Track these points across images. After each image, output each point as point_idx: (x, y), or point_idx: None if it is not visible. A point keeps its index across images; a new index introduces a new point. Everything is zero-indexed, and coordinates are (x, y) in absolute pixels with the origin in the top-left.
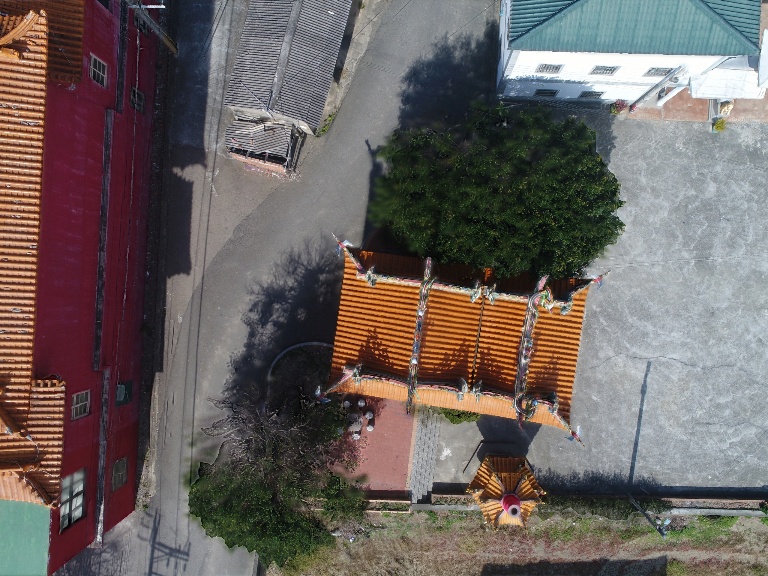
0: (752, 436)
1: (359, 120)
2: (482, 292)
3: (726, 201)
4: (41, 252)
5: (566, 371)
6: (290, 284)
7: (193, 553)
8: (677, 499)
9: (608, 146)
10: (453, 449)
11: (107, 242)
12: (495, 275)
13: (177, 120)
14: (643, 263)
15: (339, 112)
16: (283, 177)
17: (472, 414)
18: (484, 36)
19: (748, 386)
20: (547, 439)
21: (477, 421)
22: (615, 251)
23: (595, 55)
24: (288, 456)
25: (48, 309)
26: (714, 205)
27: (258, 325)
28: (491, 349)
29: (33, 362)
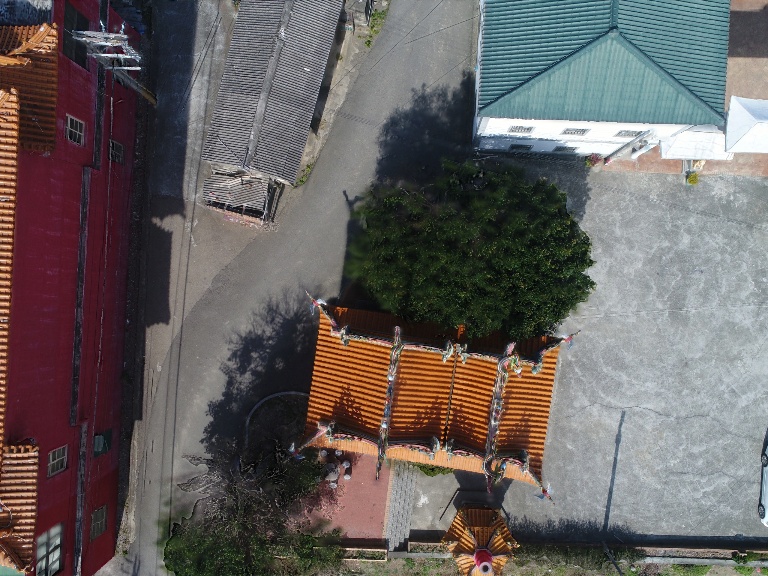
0: (725, 485)
1: (337, 171)
2: (454, 350)
3: (700, 253)
4: (14, 321)
5: (538, 428)
6: (268, 334)
7: None
8: (651, 548)
9: (583, 197)
10: (430, 497)
11: (84, 298)
12: (466, 335)
13: (156, 170)
14: (618, 313)
15: (317, 163)
16: (261, 227)
17: (446, 467)
18: (460, 88)
19: (721, 436)
20: (523, 487)
21: None
22: (590, 301)
23: (564, 120)
24: (261, 514)
25: (22, 373)
26: (688, 257)
27: (236, 374)
28: (463, 406)
29: (6, 429)
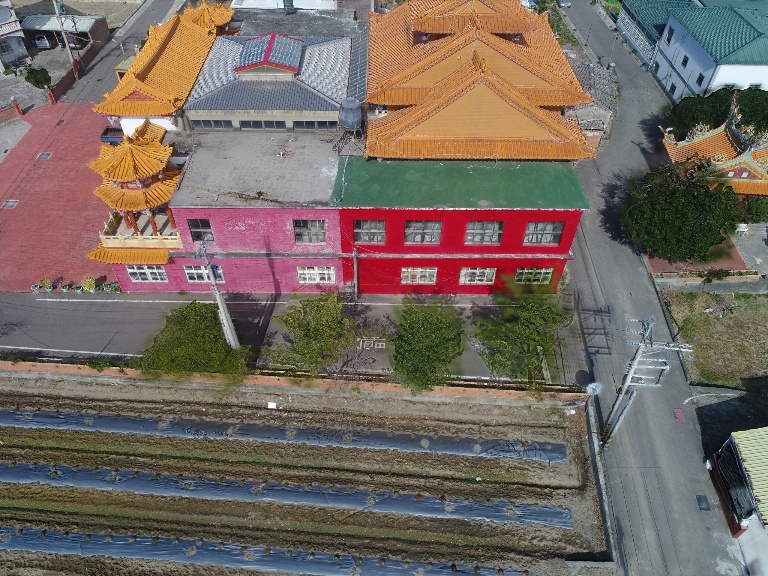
0: None
1: (623, 135)
2: None
3: None
4: None
5: None
6: (619, 184)
7: (613, 311)
8: None
9: None
10: (762, 259)
11: None
12: (755, 133)
13: None
14: None
15: None
16: None
17: None
18: None
19: None
20: None
21: (767, 245)
22: None
23: (752, 73)
24: None
25: None
26: None
27: None
28: None
29: None
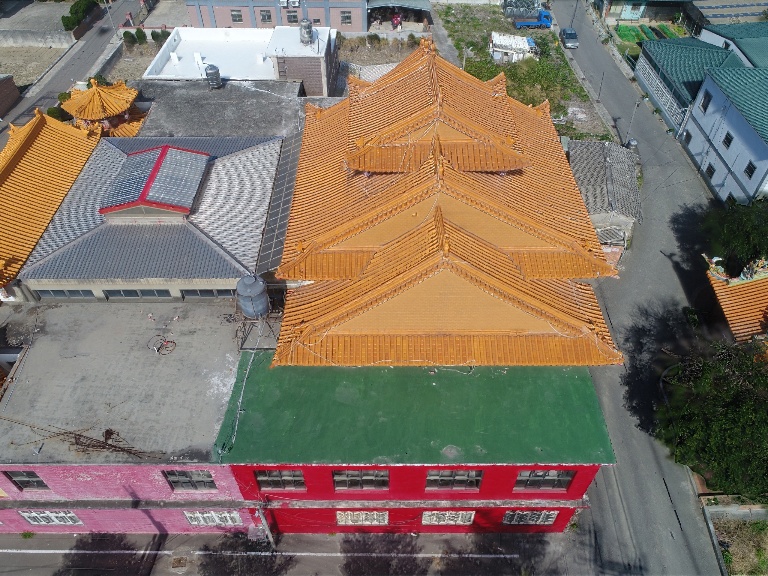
0: None
1: (649, 242)
2: None
3: None
4: None
5: None
6: (647, 328)
7: (647, 571)
8: None
9: None
10: None
11: None
12: None
13: None
14: None
15: (633, 239)
16: None
17: None
18: (709, 205)
19: None
20: None
21: None
22: None
23: None
24: None
25: None
26: None
27: (634, 355)
28: None
29: None
